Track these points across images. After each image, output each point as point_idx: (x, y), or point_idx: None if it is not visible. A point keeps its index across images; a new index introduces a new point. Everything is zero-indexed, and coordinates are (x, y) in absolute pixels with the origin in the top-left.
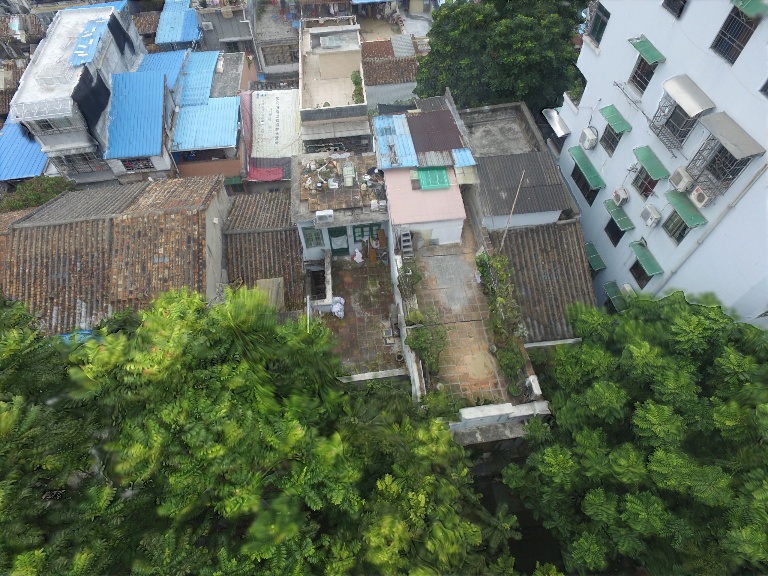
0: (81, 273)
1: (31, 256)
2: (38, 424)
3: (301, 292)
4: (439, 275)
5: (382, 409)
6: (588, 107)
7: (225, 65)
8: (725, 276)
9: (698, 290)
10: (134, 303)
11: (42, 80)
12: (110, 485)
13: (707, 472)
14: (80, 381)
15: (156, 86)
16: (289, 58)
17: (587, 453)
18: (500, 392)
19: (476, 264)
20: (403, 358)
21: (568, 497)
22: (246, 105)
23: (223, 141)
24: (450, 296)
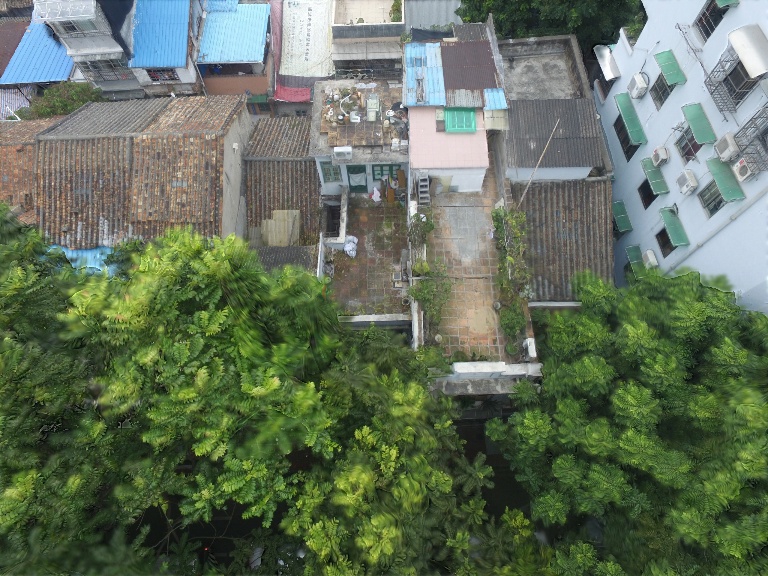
0: (103, 191)
1: (56, 169)
2: (35, 366)
3: (317, 226)
4: (454, 224)
5: (373, 360)
6: (644, 49)
7: None
8: (751, 258)
9: (721, 268)
10: (153, 225)
11: None
12: (103, 421)
13: (676, 458)
14: (80, 321)
15: None
16: None
17: (567, 422)
18: (497, 349)
19: (492, 218)
20: (409, 303)
21: (544, 456)
22: (276, 14)
23: (250, 55)
24: (462, 247)
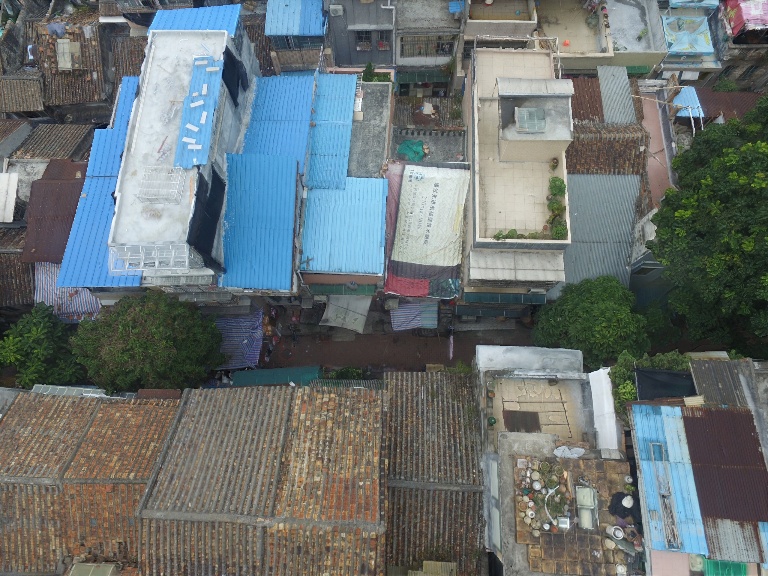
0: None
1: (165, 555)
2: None
3: (473, 569)
4: None
5: None
6: None
7: (365, 106)
8: None
9: None
10: None
11: (145, 198)
12: None
13: None
14: None
15: (286, 180)
16: (434, 50)
17: None
18: None
19: None
20: None
21: None
22: (393, 189)
23: (366, 263)
24: None
